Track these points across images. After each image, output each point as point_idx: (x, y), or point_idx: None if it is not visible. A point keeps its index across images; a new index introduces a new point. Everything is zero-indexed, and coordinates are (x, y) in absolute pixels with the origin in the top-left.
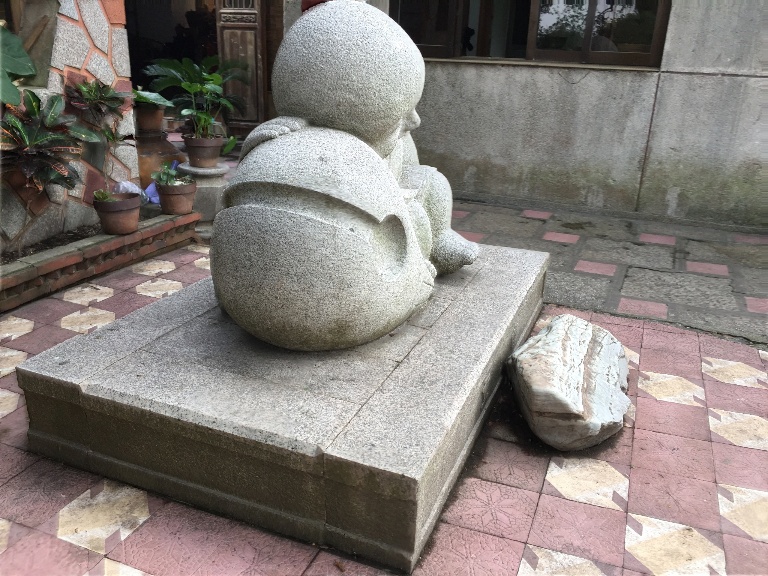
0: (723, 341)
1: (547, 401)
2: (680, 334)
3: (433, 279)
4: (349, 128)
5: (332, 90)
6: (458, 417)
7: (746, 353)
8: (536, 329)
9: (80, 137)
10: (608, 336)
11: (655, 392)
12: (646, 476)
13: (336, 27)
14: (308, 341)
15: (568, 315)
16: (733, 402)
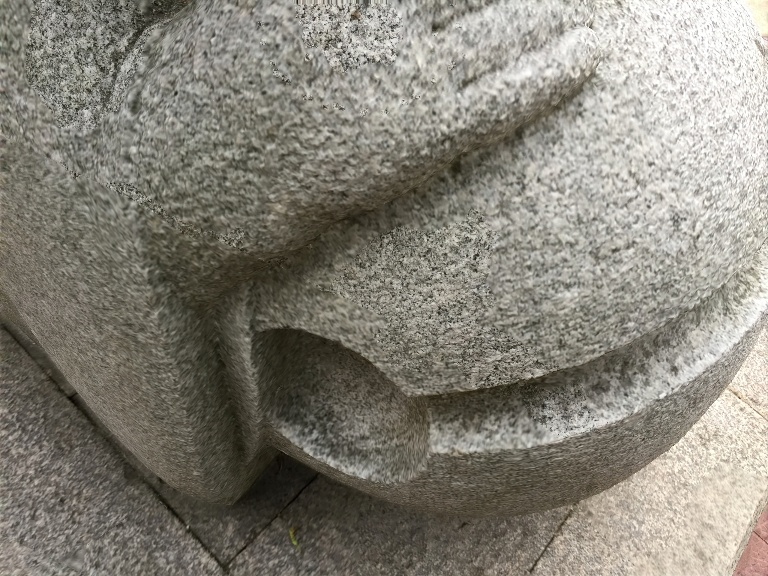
0: None
1: None
2: None
3: None
4: None
5: None
6: None
7: None
8: None
9: None
10: None
11: None
12: None
13: None
14: None
15: None
16: None
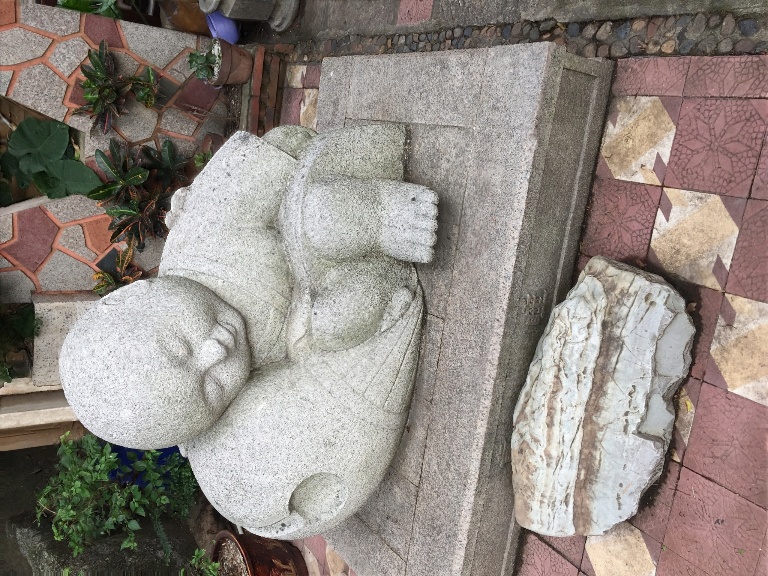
0: None
1: None
2: None
3: (413, 303)
4: None
5: None
6: (465, 571)
7: None
8: (599, 169)
9: (141, 181)
10: (638, 300)
11: (730, 369)
12: (673, 568)
13: None
14: None
15: (559, 321)
16: None
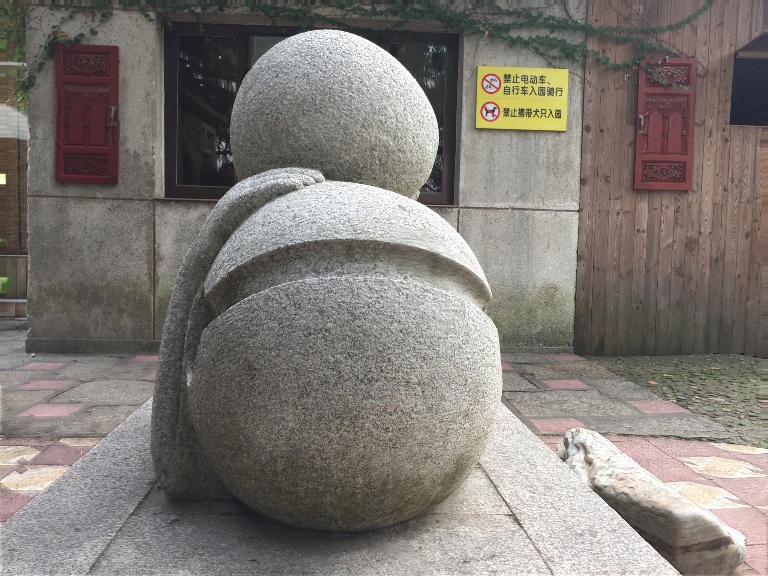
0: (672, 440)
1: (696, 527)
2: (629, 441)
3: None
4: (380, 185)
5: (367, 127)
6: None
7: (704, 447)
8: None
9: None
10: None
11: None
12: None
13: (358, 49)
14: (406, 505)
15: None
16: (764, 495)
